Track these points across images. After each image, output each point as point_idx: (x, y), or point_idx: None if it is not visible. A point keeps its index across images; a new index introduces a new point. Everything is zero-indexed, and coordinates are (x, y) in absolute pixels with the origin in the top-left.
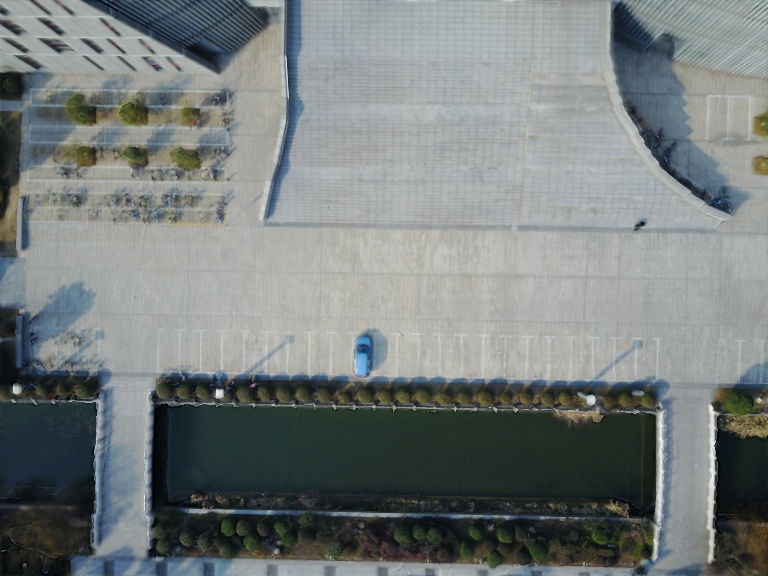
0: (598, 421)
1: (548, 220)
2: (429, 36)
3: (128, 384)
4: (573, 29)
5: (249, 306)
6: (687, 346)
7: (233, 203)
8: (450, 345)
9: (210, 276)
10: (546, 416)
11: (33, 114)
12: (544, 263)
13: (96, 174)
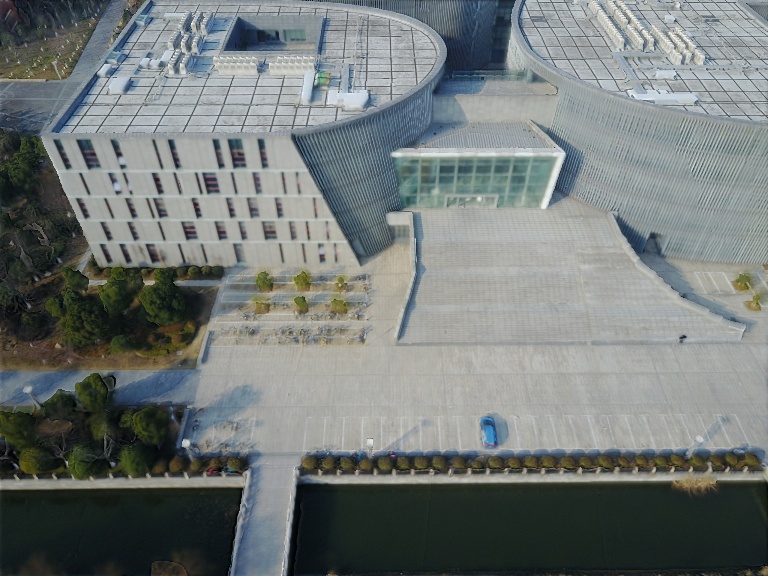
0: (714, 480)
1: (613, 336)
2: (505, 231)
3: (275, 462)
4: (594, 228)
5: (385, 399)
6: (762, 419)
7: (371, 333)
8: (561, 423)
9: (353, 379)
10: (665, 488)
11: (227, 288)
12: (620, 364)
13: (268, 318)
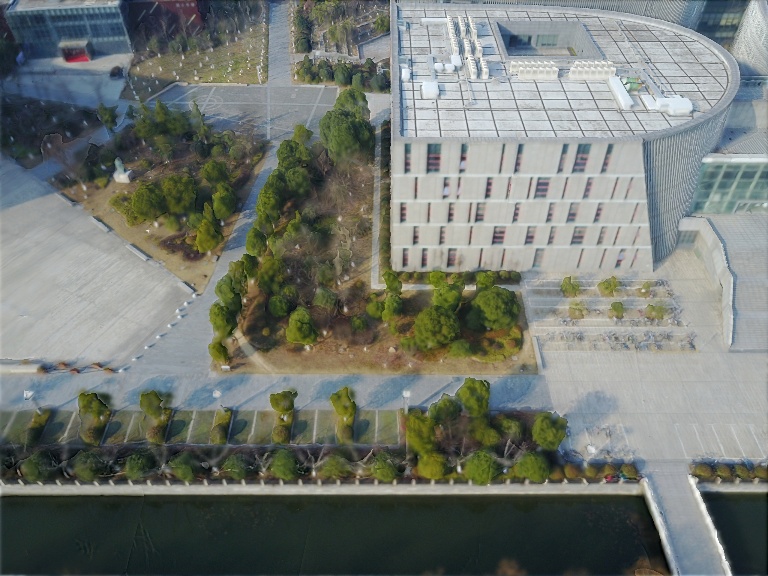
0: None
1: None
2: None
3: (663, 469)
4: None
5: (744, 406)
6: None
7: (697, 339)
8: None
9: (702, 385)
10: None
11: (529, 292)
12: None
13: (586, 324)
